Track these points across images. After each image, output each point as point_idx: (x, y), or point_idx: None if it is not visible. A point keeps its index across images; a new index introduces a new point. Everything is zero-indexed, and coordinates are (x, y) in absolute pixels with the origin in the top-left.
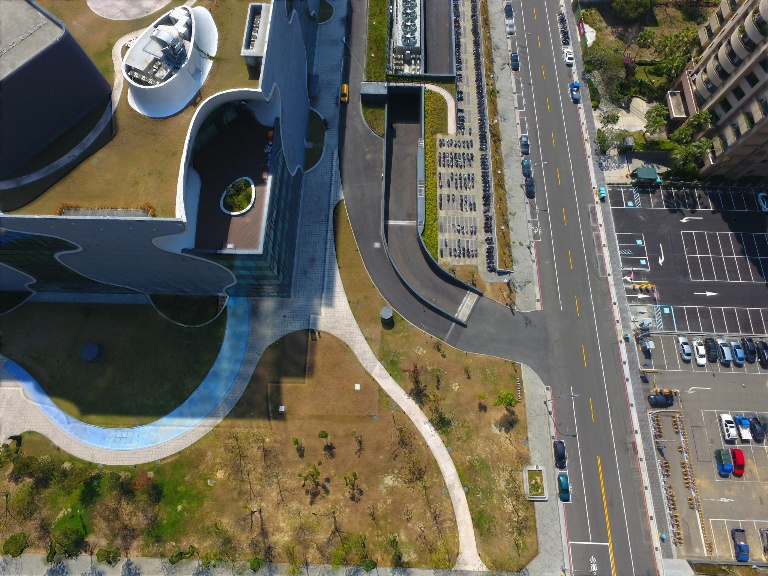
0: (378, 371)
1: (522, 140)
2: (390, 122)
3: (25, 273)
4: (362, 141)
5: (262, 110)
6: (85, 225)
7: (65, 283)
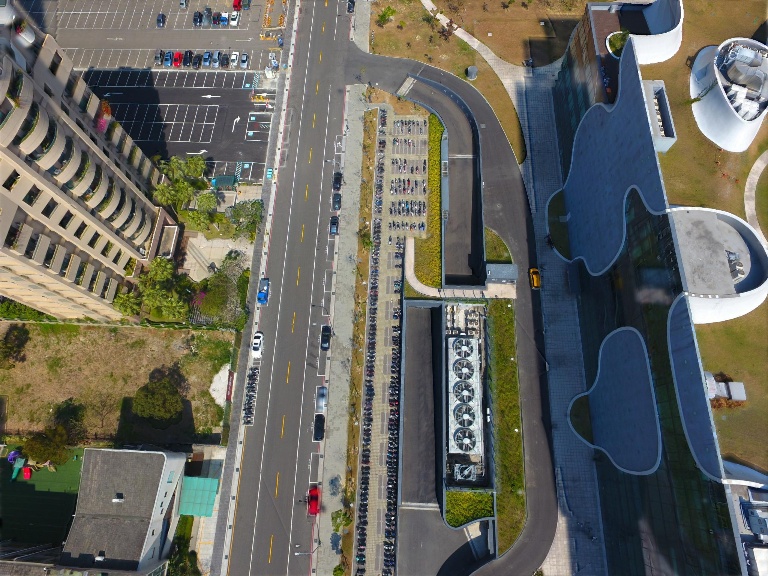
0: (475, 44)
1: None
2: (475, 276)
3: None
4: (507, 223)
5: None
6: None
7: None
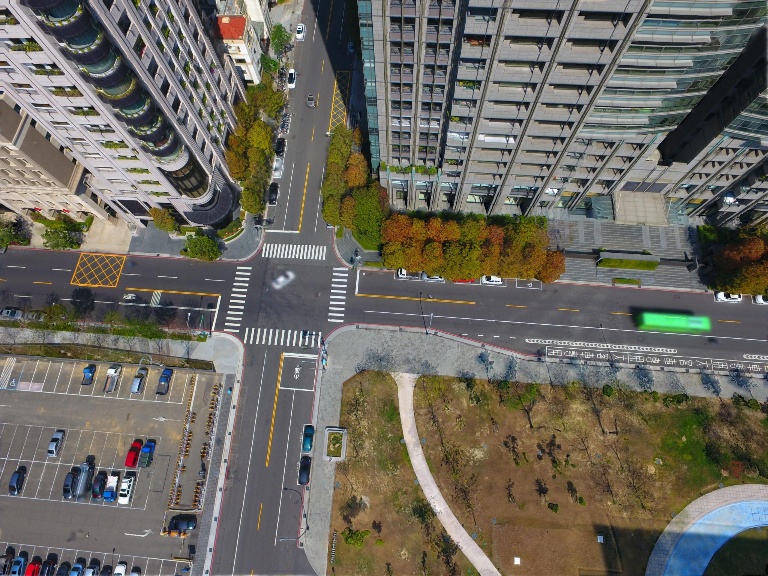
0: None
1: None
2: None
3: None
4: None
5: None
6: None
7: None
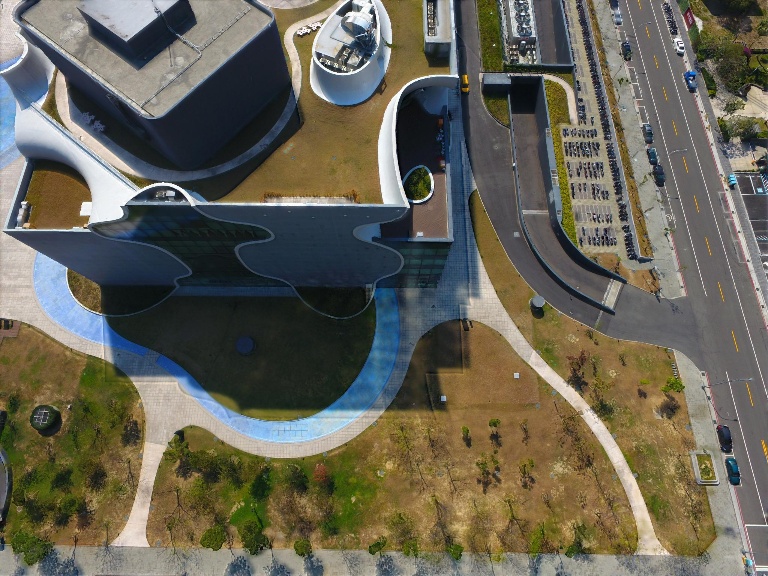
0: (534, 359)
1: (646, 129)
2: None
3: (188, 266)
4: (488, 131)
5: (432, 98)
6: (300, 213)
7: (217, 276)
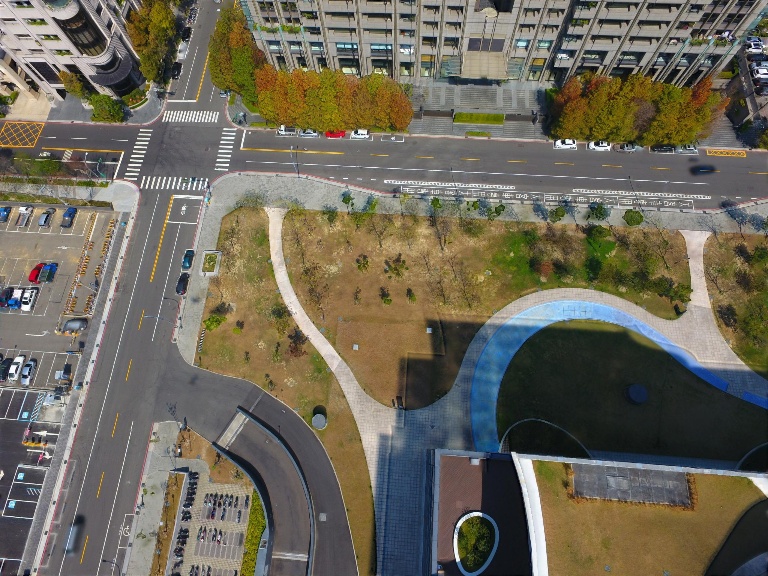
0: (335, 362)
1: None
2: None
3: None
4: None
5: None
6: None
7: None
